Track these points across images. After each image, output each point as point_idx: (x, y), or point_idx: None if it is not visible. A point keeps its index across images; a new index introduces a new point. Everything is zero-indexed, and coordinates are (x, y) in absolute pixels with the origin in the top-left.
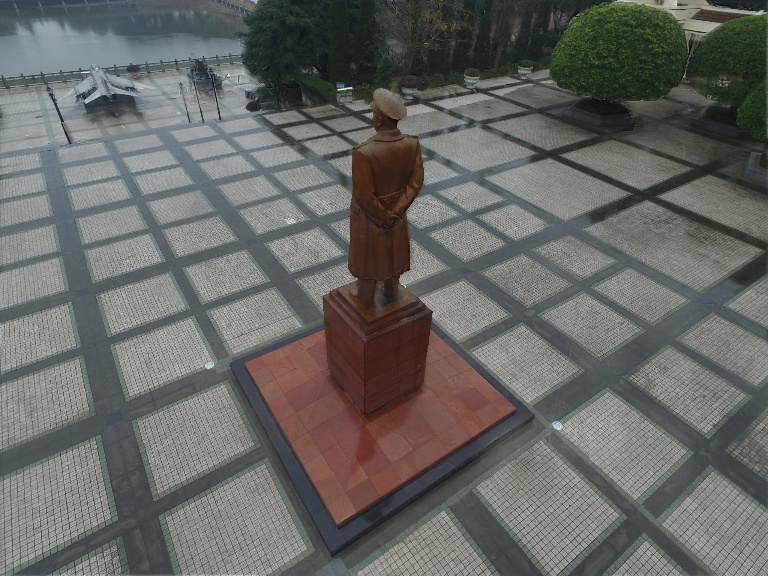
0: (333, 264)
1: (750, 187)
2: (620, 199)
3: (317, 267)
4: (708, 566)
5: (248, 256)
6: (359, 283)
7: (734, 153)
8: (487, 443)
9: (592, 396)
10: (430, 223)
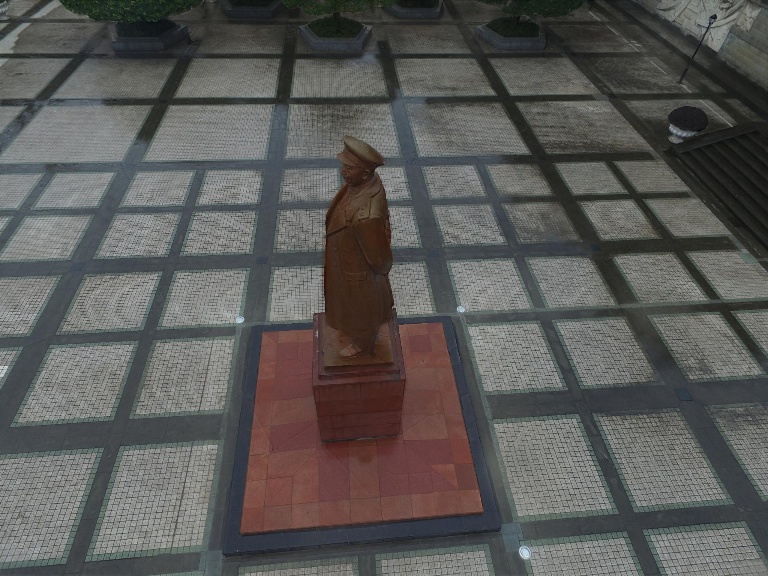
0: (142, 364)
1: (328, 57)
2: (273, 114)
3: (130, 383)
4: (579, 306)
5: (18, 459)
6: (364, 340)
7: (286, 32)
8: (459, 360)
9: (448, 274)
10: (166, 243)
